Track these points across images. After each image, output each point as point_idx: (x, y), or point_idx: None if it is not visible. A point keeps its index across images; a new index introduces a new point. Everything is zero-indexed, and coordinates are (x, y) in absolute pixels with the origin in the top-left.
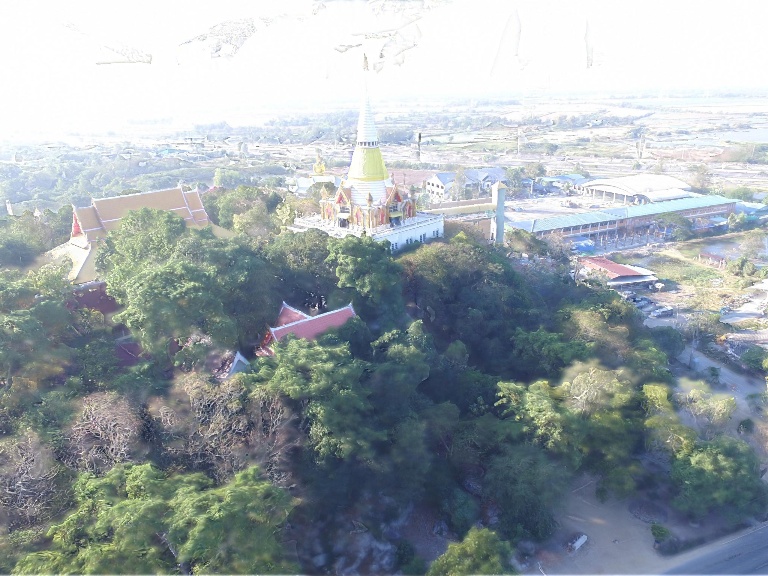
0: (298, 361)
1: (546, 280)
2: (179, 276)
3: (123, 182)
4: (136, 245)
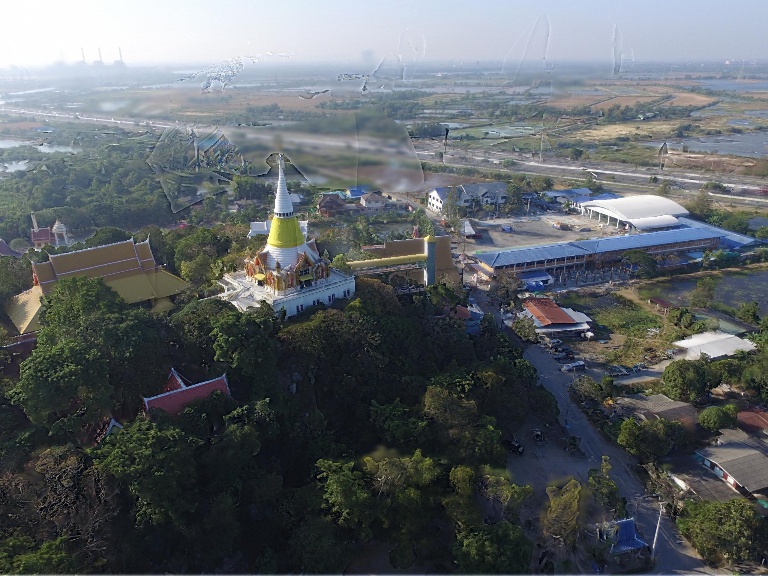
0: (129, 445)
1: (451, 337)
2: (65, 358)
3: (151, 183)
4: (61, 312)
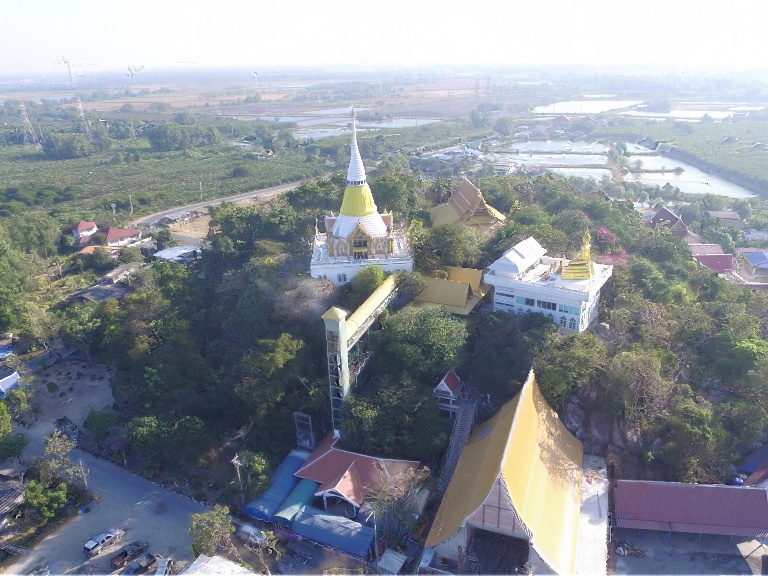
0: None
1: None
2: None
3: None
4: None
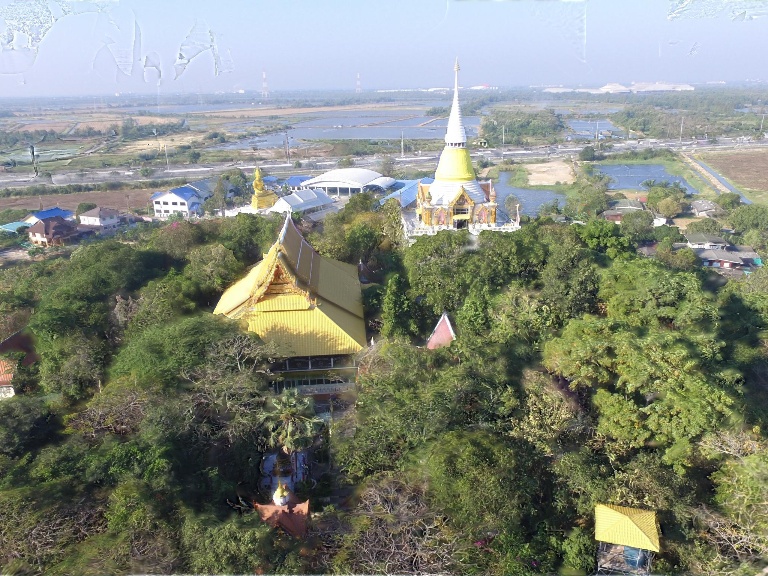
0: None
1: None
2: None
3: None
4: (484, 271)
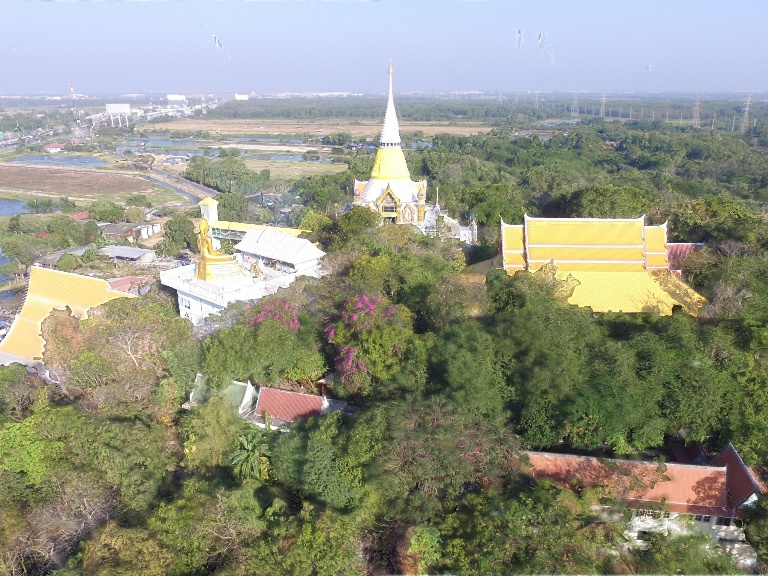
0: None
1: None
2: None
3: None
4: None
